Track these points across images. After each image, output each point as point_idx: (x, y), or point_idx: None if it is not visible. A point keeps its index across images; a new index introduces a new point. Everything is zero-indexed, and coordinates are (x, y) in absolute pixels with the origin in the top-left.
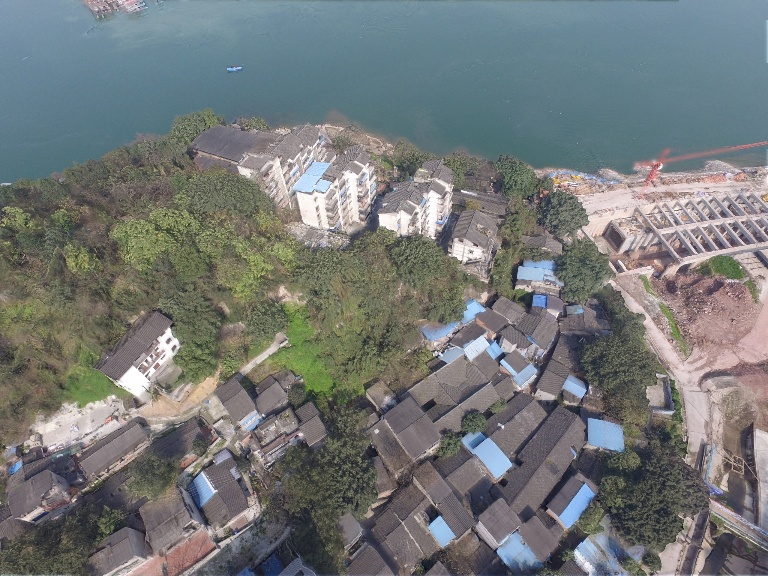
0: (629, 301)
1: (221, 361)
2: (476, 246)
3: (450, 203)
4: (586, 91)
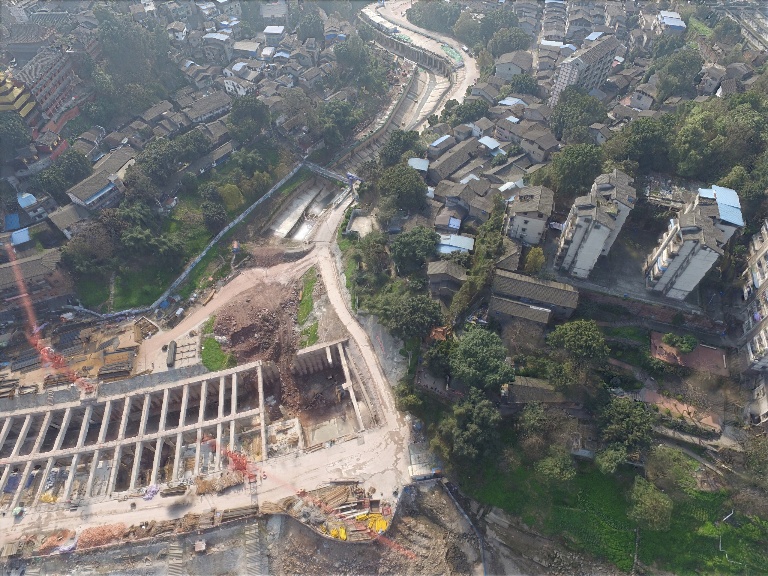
0: (341, 308)
1: None
2: None
3: None
4: None
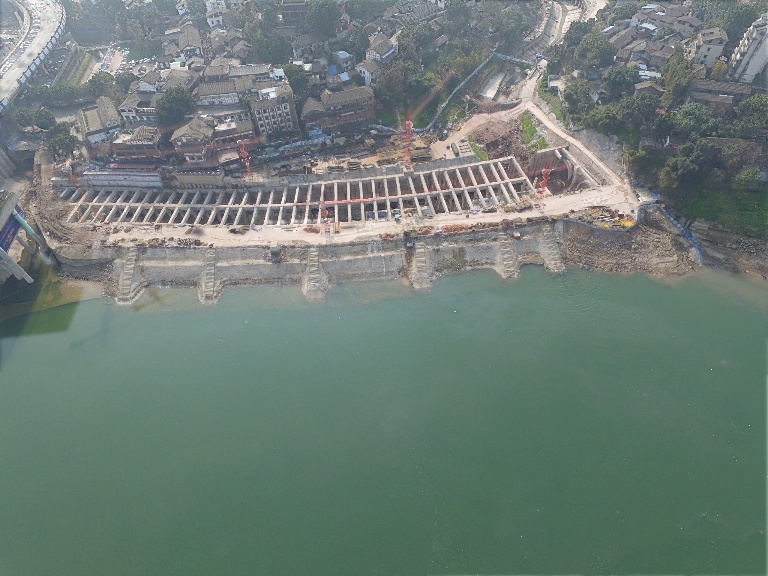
0: (558, 130)
1: None
2: None
3: None
4: (588, 464)
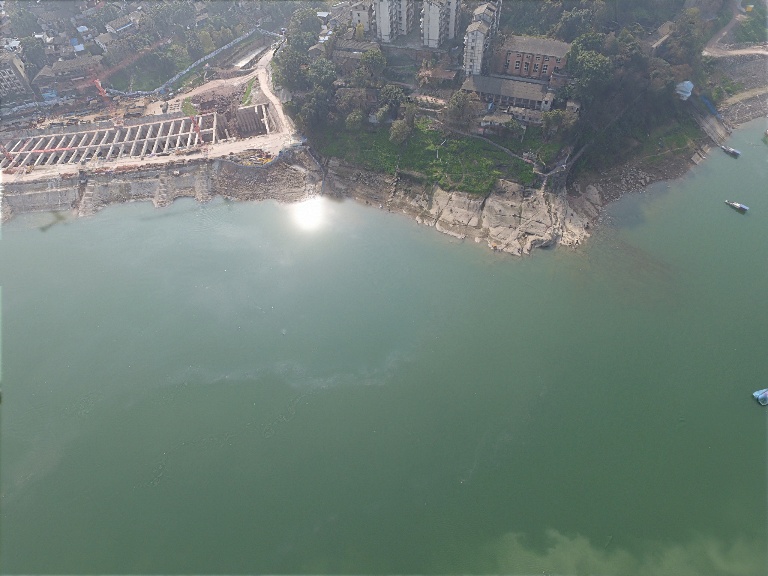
0: (267, 91)
1: None
2: None
3: None
4: (127, 335)
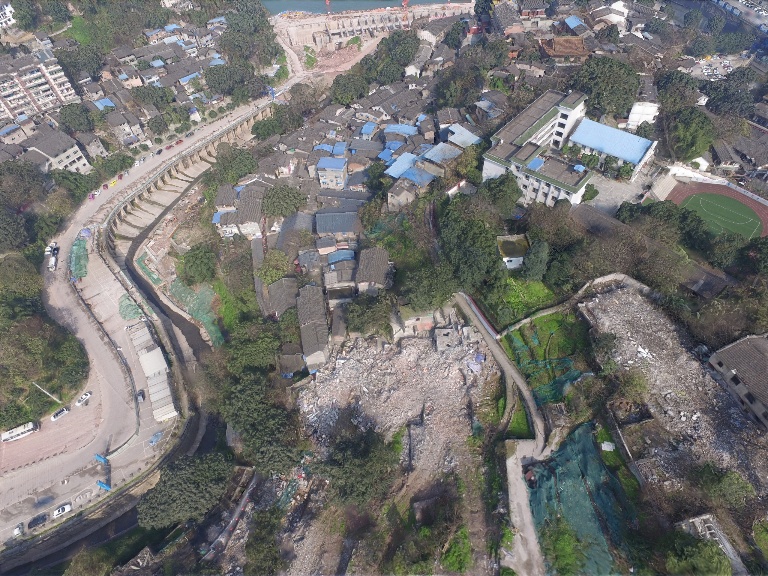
0: (291, 53)
1: (38, 28)
2: None
3: None
4: None
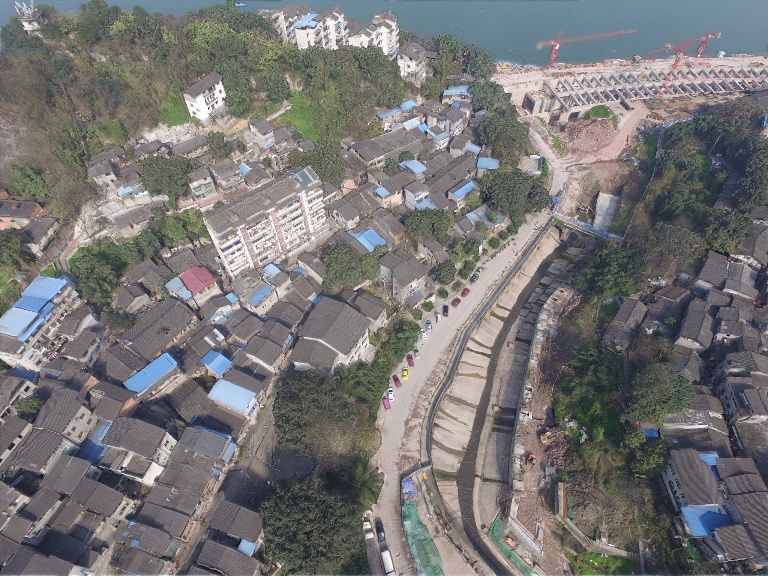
0: None
1: (251, 112)
2: (411, 60)
3: (398, 44)
4: (522, 18)
